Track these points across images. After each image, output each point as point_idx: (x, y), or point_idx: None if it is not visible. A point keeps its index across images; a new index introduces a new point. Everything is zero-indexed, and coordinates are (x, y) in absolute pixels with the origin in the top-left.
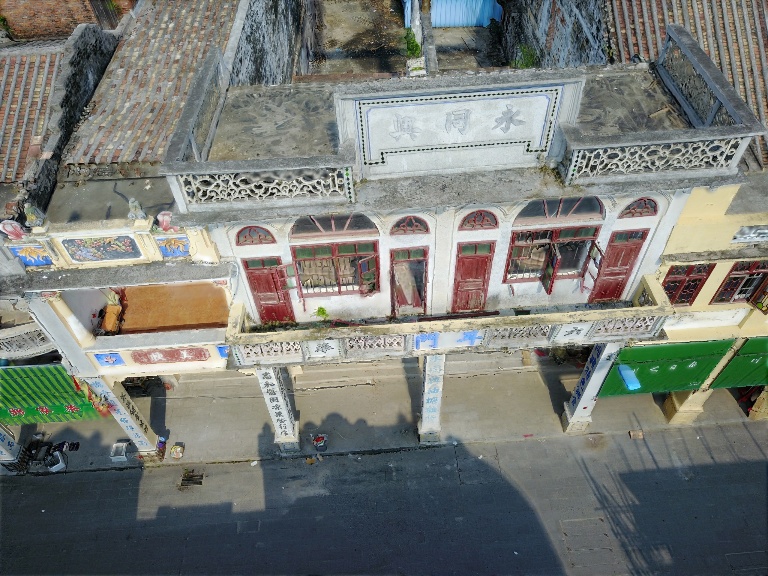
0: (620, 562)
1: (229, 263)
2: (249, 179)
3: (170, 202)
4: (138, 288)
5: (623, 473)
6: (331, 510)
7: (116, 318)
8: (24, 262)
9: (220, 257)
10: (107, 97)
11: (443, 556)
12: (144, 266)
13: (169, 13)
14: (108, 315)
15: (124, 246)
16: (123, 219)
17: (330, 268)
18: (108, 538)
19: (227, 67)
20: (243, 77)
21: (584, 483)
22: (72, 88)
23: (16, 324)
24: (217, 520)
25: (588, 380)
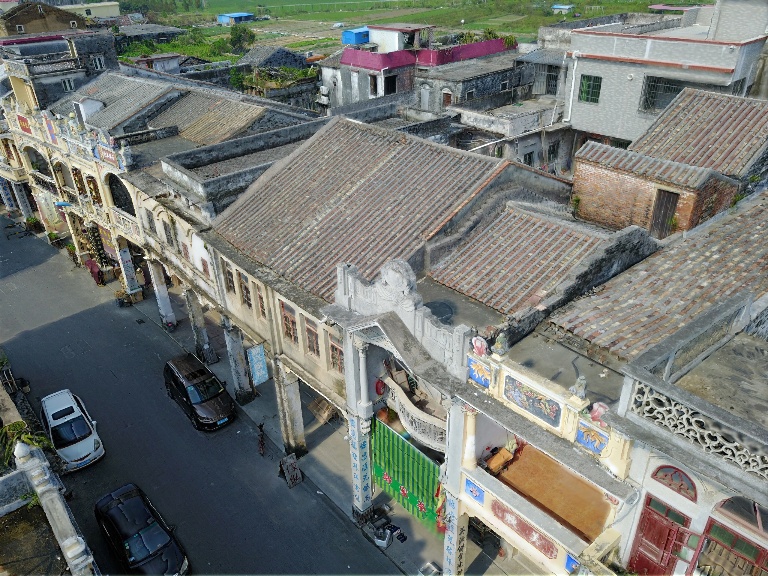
0: None
1: (633, 488)
2: (707, 424)
3: (613, 399)
4: (536, 451)
5: None
6: None
7: (503, 462)
8: (470, 374)
9: (627, 476)
10: (618, 288)
11: None
12: (554, 437)
13: (720, 246)
14: (498, 455)
15: (550, 410)
16: (564, 388)
17: (744, 573)
18: None
19: (751, 314)
20: (763, 330)
21: None
22: (594, 268)
23: (433, 414)
24: None
25: None
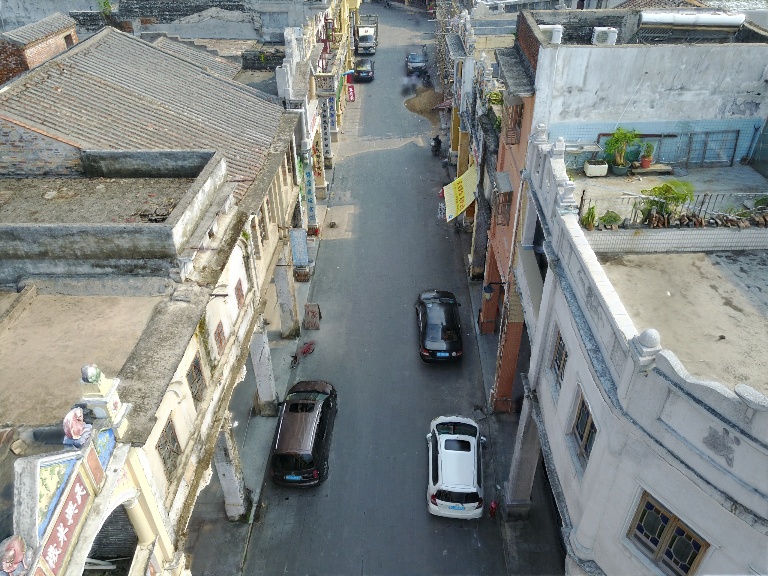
0: (391, 140)
1: None
2: None
3: None
4: None
5: (358, 136)
6: (358, 189)
7: None
8: None
9: None
10: None
11: (383, 168)
12: None
13: None
14: None
15: None
16: None
17: None
18: (359, 244)
19: None
20: None
21: (360, 142)
22: None
23: None
24: (356, 216)
25: (334, 101)
